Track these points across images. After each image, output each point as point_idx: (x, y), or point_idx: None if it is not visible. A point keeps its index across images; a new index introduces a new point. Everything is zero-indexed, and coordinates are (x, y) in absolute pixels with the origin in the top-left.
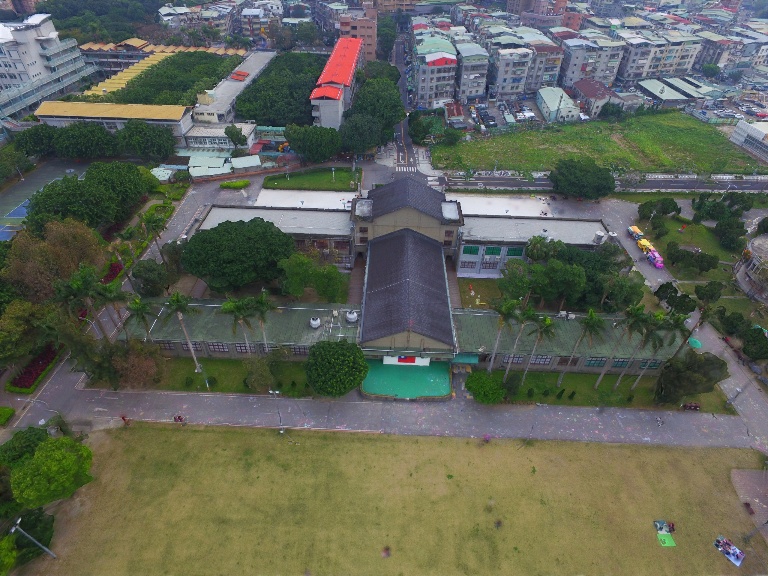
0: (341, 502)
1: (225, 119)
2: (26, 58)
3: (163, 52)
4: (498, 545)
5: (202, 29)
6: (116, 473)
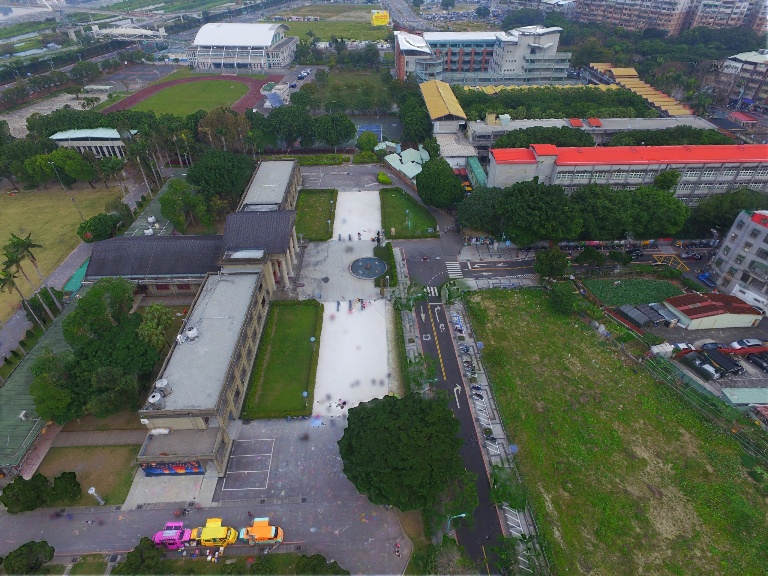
0: None
1: (473, 140)
2: (508, 56)
3: (621, 86)
4: None
5: (675, 75)
6: (98, 194)
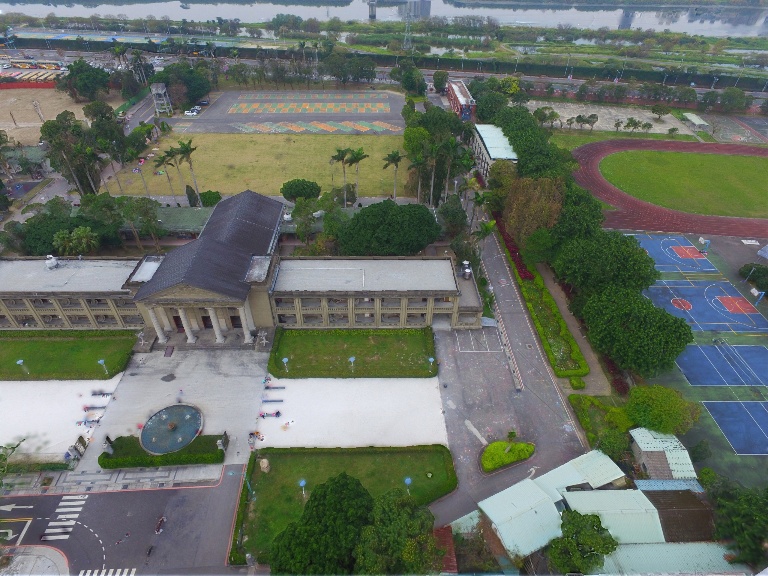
0: (302, 177)
1: None
2: None
3: None
4: (236, 170)
5: None
6: None
